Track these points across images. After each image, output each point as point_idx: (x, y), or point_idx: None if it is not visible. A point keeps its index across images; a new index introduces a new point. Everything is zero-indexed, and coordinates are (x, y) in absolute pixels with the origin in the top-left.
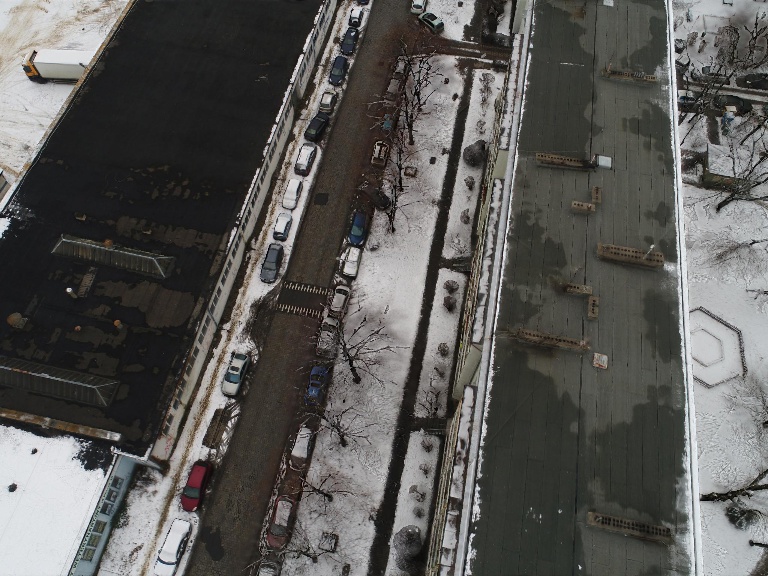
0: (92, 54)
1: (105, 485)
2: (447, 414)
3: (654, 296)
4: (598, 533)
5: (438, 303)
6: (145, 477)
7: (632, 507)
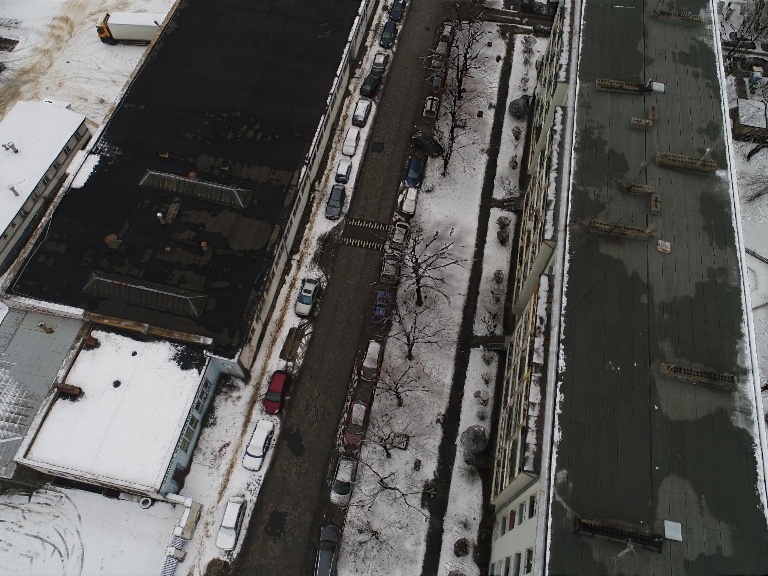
0: (161, 16)
1: (200, 383)
2: (504, 333)
3: (708, 196)
4: (670, 381)
5: (491, 238)
6: (229, 384)
7: (699, 362)
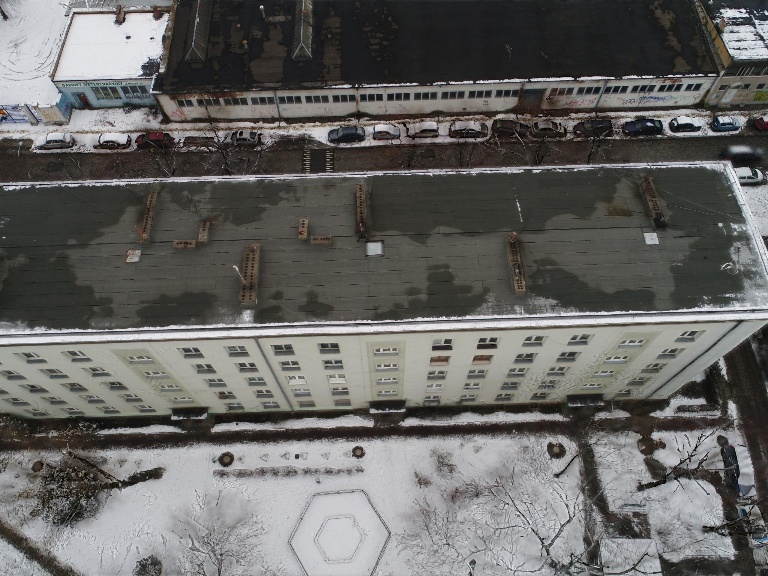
0: None
1: (132, 79)
2: None
3: (210, 301)
4: None
5: None
6: (158, 112)
7: (3, 287)
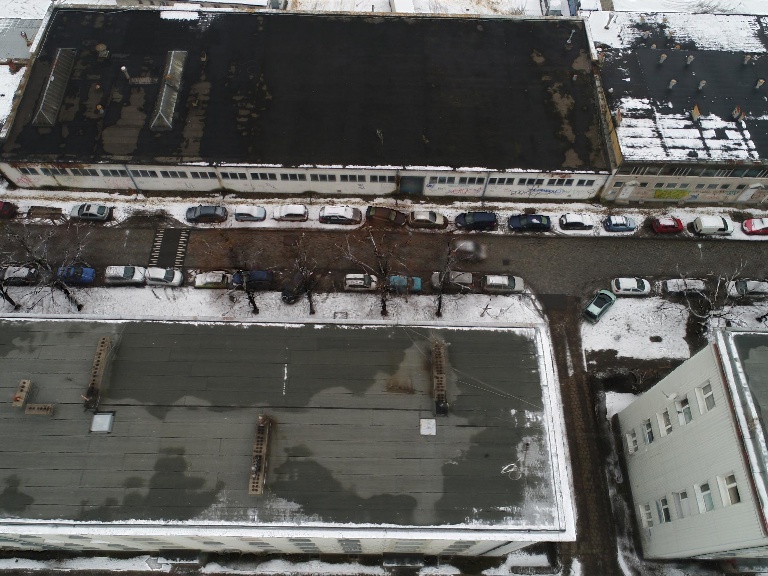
0: None
1: None
2: None
3: None
4: None
5: None
6: None
7: None
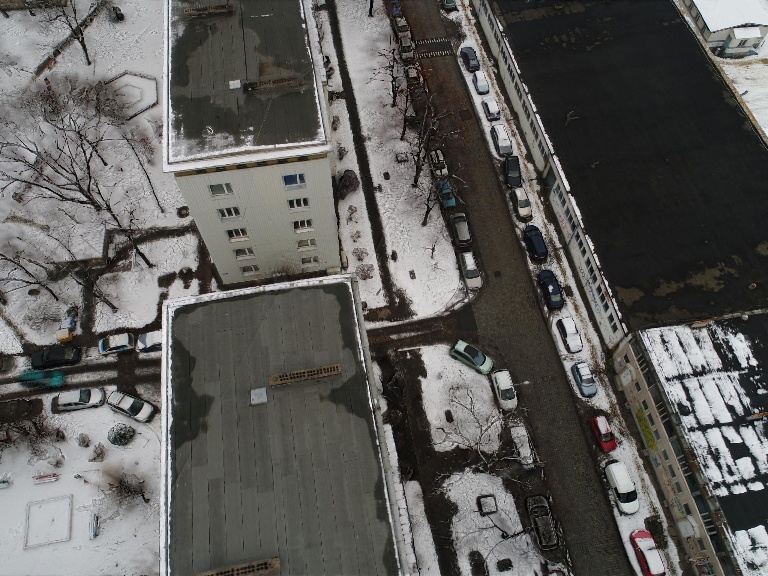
0: None
1: None
2: None
3: None
4: None
5: (335, 69)
6: None
7: None
